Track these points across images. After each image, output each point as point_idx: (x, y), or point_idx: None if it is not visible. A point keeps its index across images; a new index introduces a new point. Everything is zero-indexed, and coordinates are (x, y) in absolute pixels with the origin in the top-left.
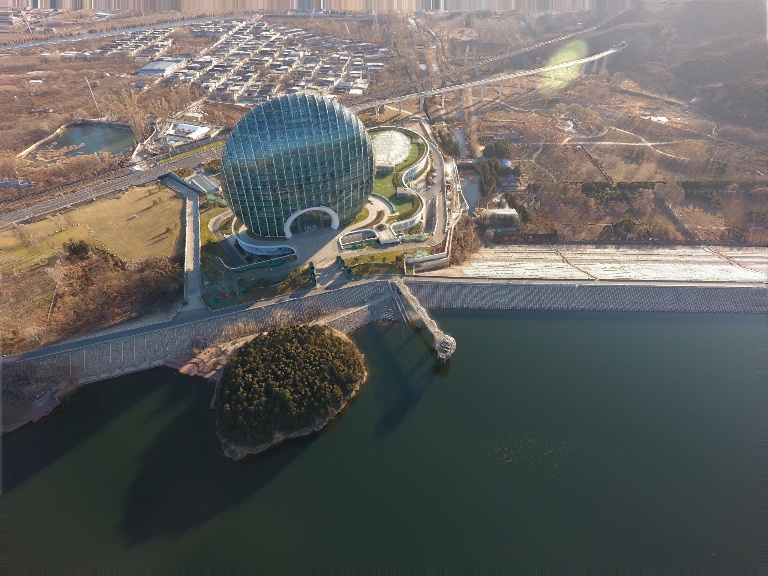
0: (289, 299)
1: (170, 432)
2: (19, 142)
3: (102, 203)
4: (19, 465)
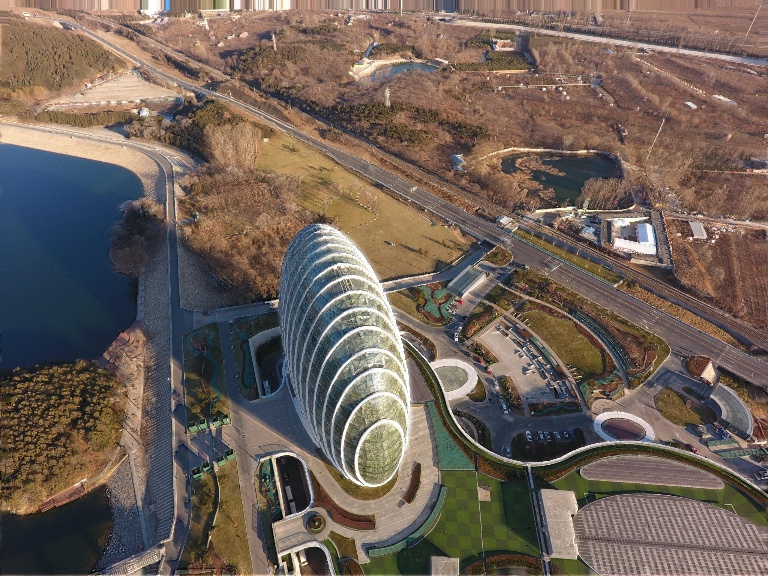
0: (175, 404)
1: (56, 344)
2: (539, 140)
3: (420, 217)
4: (78, 273)
